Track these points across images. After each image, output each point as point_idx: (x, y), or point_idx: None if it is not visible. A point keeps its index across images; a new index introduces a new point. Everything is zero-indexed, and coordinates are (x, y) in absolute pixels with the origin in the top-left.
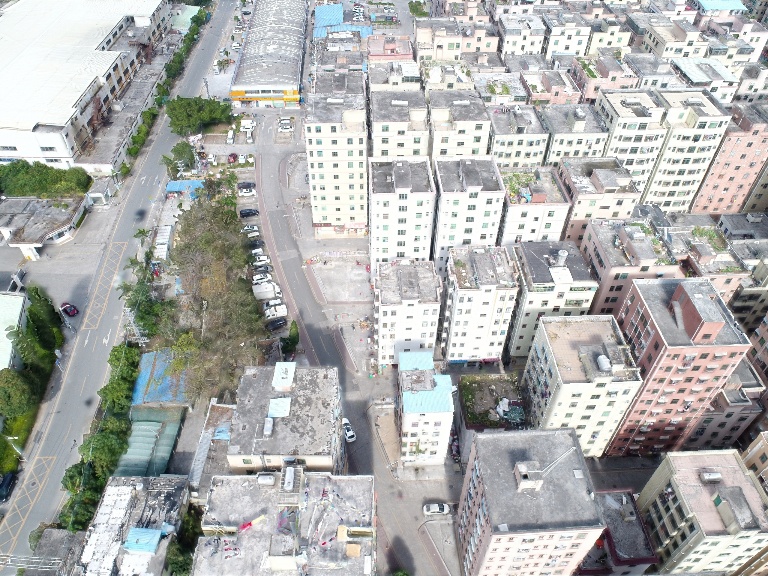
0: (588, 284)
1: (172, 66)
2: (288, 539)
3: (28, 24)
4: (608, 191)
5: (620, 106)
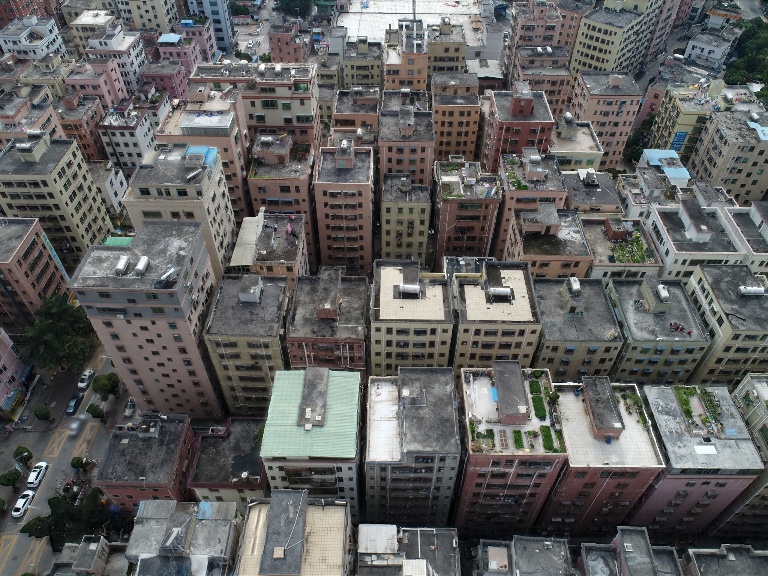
0: (564, 173)
1: None
2: (717, 82)
3: None
4: None
5: (518, 291)
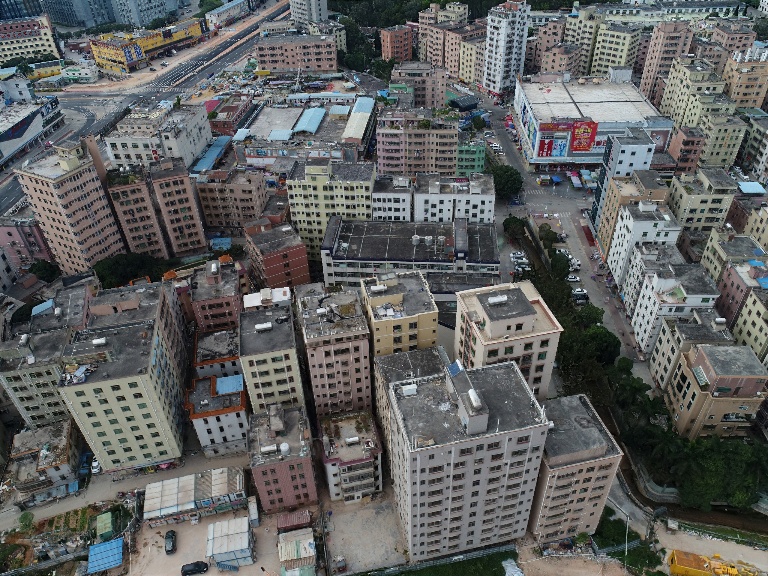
0: None
1: None
2: None
3: None
4: None
5: None
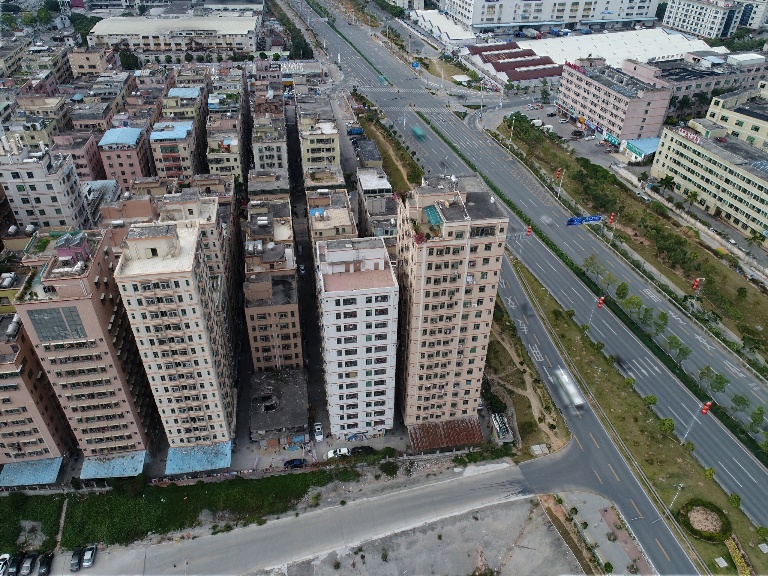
0: None
1: (189, 55)
2: None
3: (207, 19)
4: None
5: None
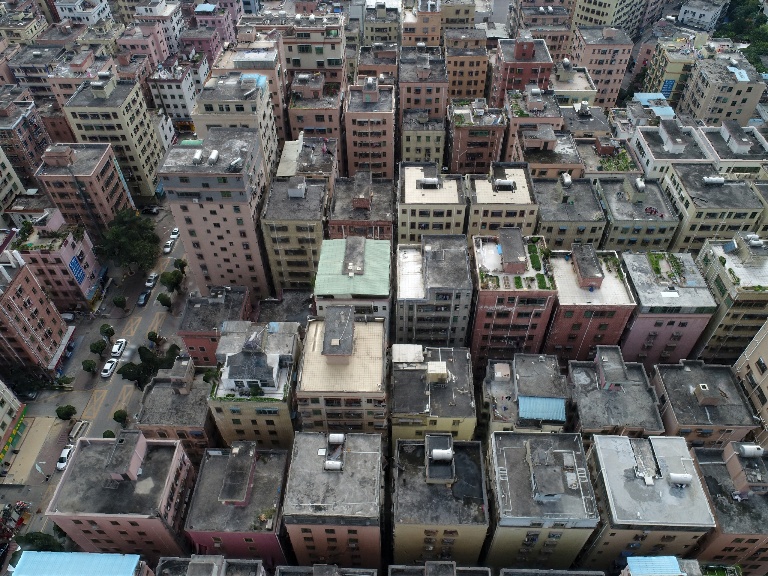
0: (562, 107)
1: None
2: (701, 34)
3: None
4: None
5: (519, 183)
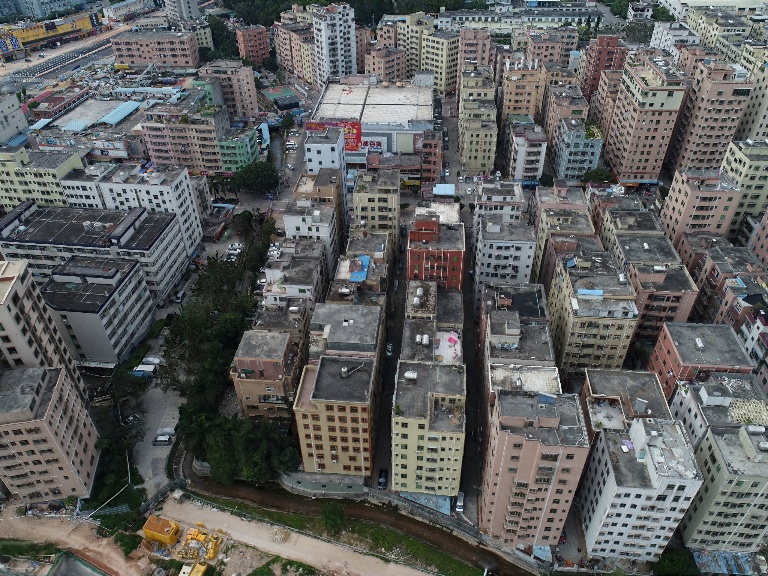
0: None
1: None
2: None
3: None
4: (687, 50)
5: None
